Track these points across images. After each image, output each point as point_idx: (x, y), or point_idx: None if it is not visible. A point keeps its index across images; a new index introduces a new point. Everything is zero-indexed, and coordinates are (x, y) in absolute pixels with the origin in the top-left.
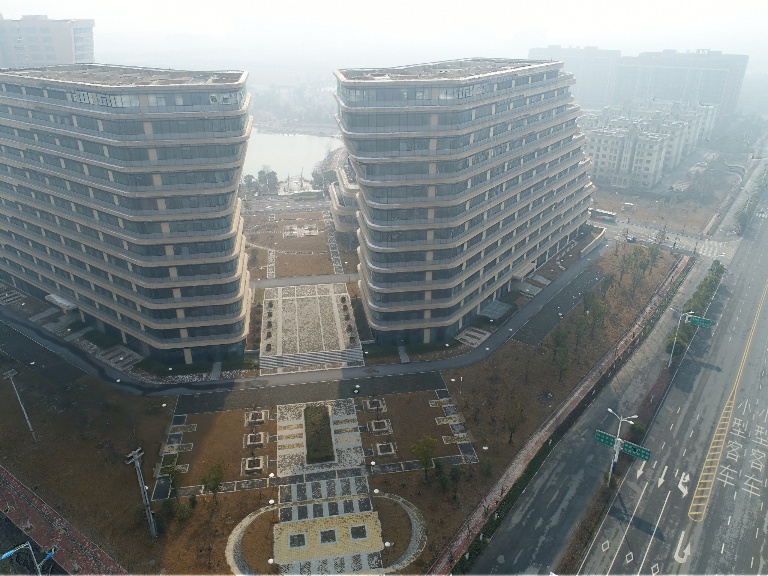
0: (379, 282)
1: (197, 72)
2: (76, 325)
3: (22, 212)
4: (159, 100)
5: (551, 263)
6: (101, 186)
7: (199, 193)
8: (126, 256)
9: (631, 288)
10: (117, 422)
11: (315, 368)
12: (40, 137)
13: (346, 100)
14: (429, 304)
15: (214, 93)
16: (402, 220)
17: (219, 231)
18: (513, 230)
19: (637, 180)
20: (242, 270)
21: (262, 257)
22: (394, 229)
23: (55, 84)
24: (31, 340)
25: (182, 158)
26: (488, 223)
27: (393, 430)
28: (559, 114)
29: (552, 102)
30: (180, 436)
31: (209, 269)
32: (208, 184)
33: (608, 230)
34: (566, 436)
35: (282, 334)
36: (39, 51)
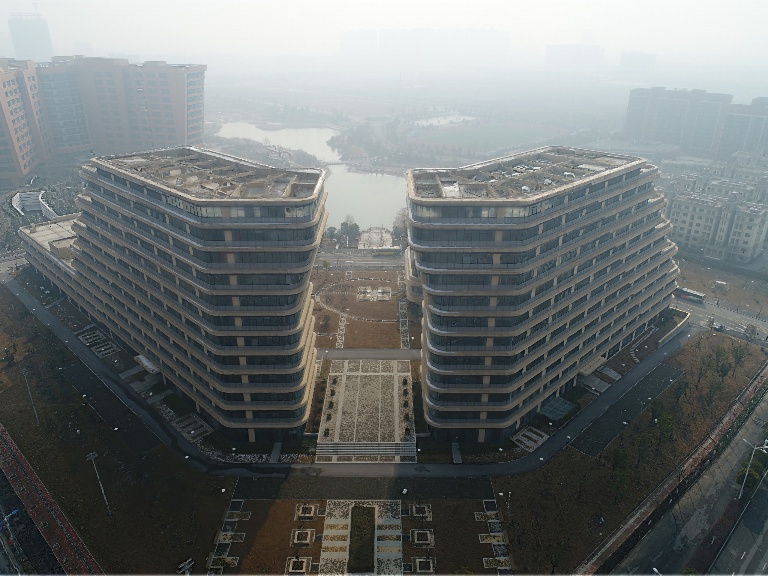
0: (436, 382)
1: (280, 170)
2: (158, 387)
3: (121, 280)
4: (239, 212)
5: (624, 353)
6: (185, 279)
7: (270, 294)
8: (203, 341)
9: (709, 393)
10: (181, 501)
11: (368, 460)
12: (139, 224)
13: (413, 213)
14: (485, 406)
15: (289, 207)
16: (462, 327)
17: (286, 327)
18: (581, 327)
19: (734, 253)
20: (308, 353)
21: (334, 323)
22: (453, 335)
23: (153, 187)
24: (119, 399)
25: (257, 262)
26: (553, 326)
27: (435, 543)
28: (640, 209)
29: (631, 200)
30: (235, 524)
31: (275, 360)
32: (279, 286)
33: (694, 313)
34: (613, 573)
35: (341, 417)
36: (156, 94)
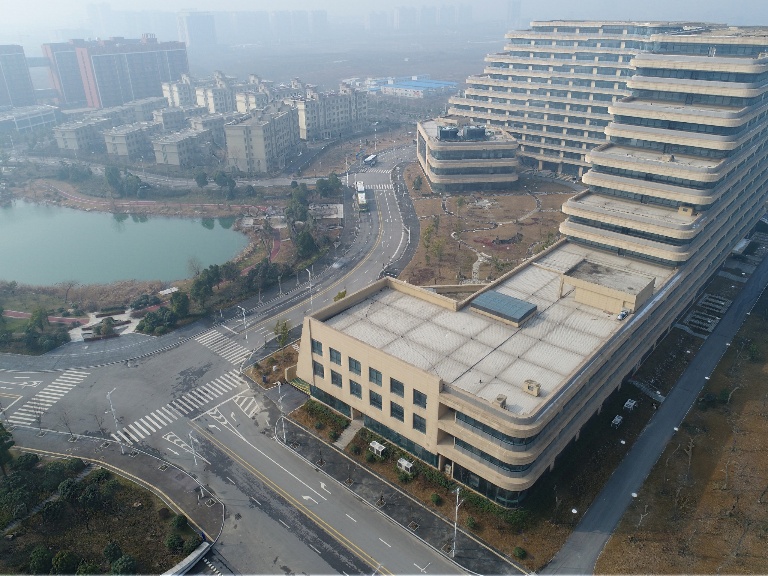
0: None
1: None
2: (741, 257)
3: None
4: None
5: None
6: None
7: None
8: None
9: None
10: None
11: None
12: None
13: None
14: None
15: None
16: None
17: None
18: None
19: None
20: None
21: (556, 212)
22: None
23: None
24: None
25: None
26: None
27: None
28: None
29: None
30: None
31: None
32: None
33: None
34: None
35: None
36: None
